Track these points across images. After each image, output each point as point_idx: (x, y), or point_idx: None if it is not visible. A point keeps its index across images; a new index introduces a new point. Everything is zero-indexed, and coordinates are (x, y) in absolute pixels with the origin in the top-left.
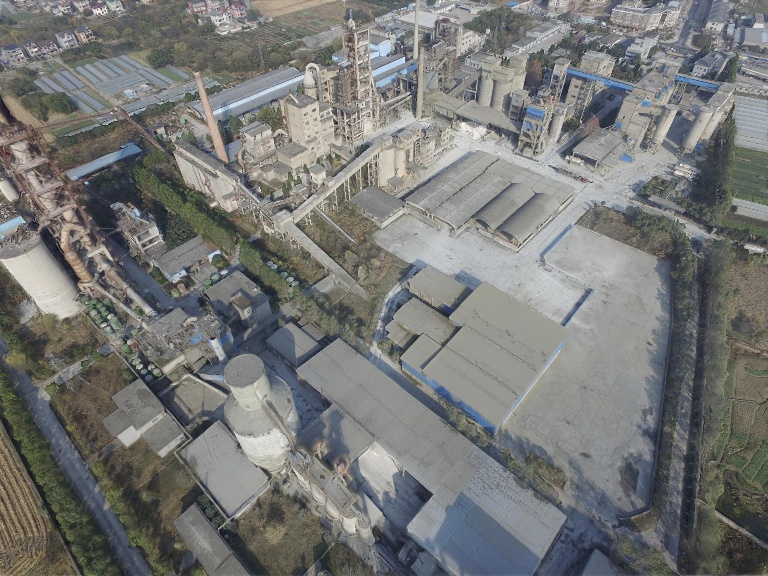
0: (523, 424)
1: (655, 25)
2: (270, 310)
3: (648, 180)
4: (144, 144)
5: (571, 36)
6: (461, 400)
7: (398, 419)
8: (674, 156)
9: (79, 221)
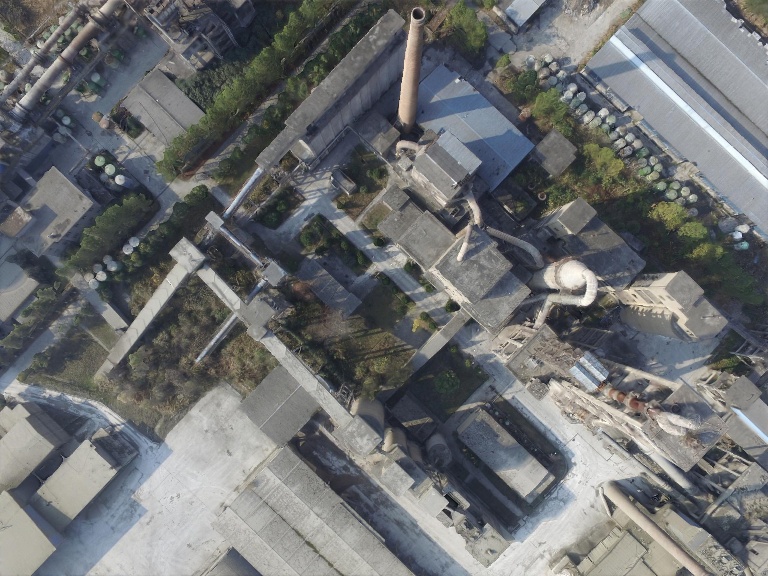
0: None
1: None
2: (55, 255)
3: None
4: None
5: None
6: None
7: None
8: None
9: None
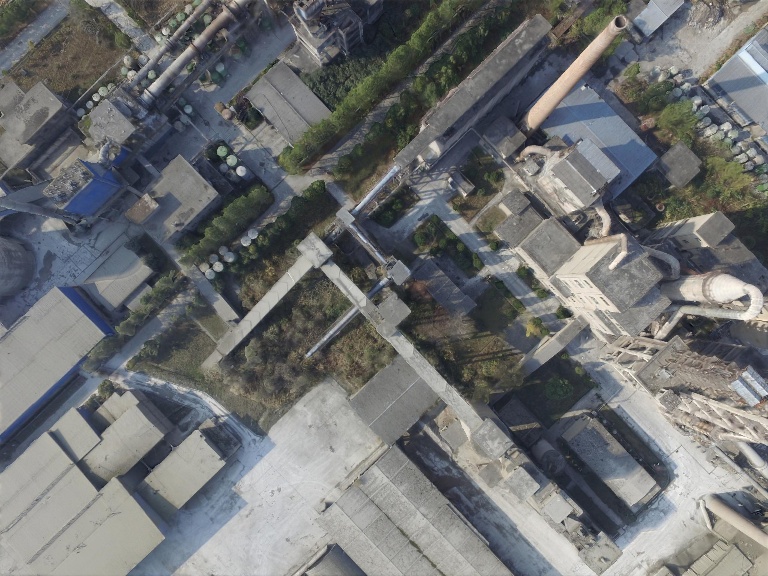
0: None
1: None
2: None
3: None
4: None
5: None
6: (5, 470)
7: None
8: None
9: None
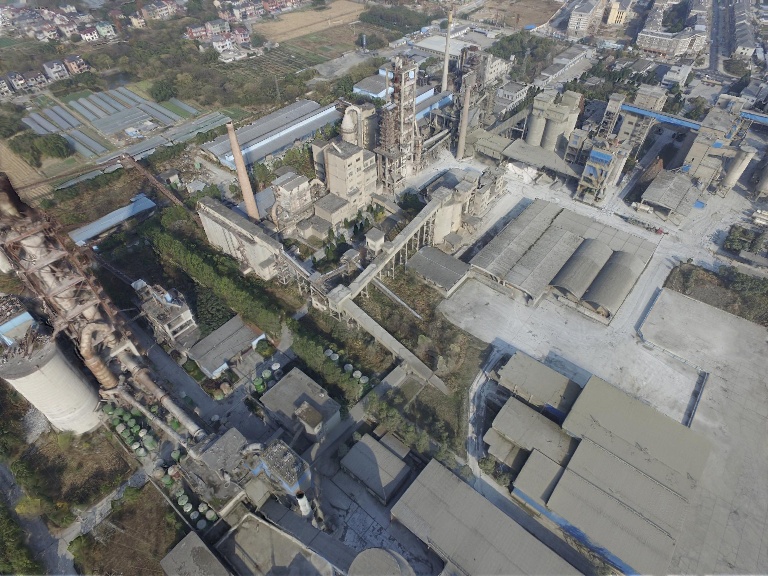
0: (676, 570)
1: (683, 50)
2: (339, 418)
3: (727, 230)
4: (156, 195)
5: (600, 62)
6: (605, 548)
7: None
8: (746, 200)
9: (102, 317)
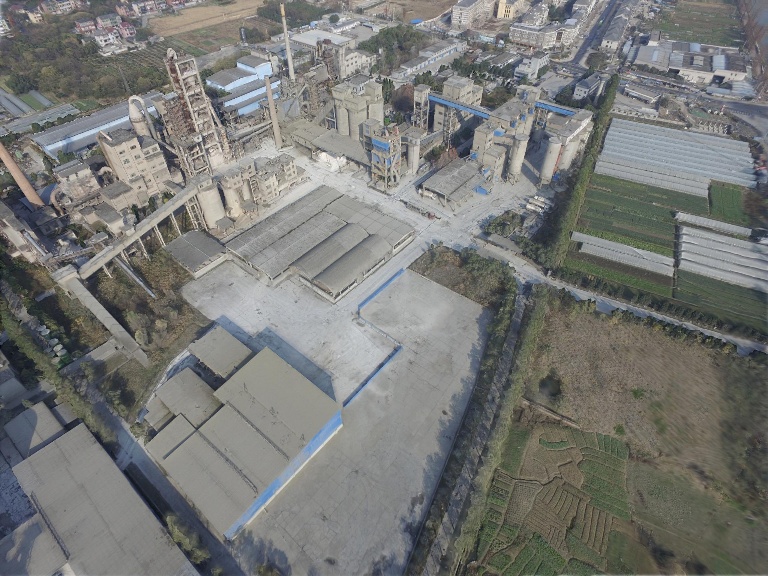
0: (272, 523)
1: (552, 43)
2: (22, 387)
3: (499, 215)
4: None
5: (465, 55)
6: (192, 501)
7: (109, 530)
8: (534, 187)
9: None
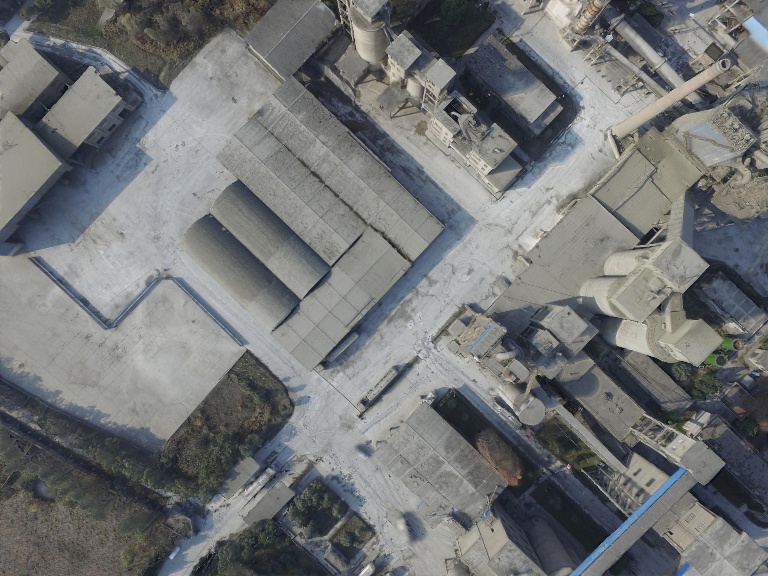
0: None
1: None
2: None
3: (363, 514)
4: None
5: None
6: None
7: None
8: None
9: None
